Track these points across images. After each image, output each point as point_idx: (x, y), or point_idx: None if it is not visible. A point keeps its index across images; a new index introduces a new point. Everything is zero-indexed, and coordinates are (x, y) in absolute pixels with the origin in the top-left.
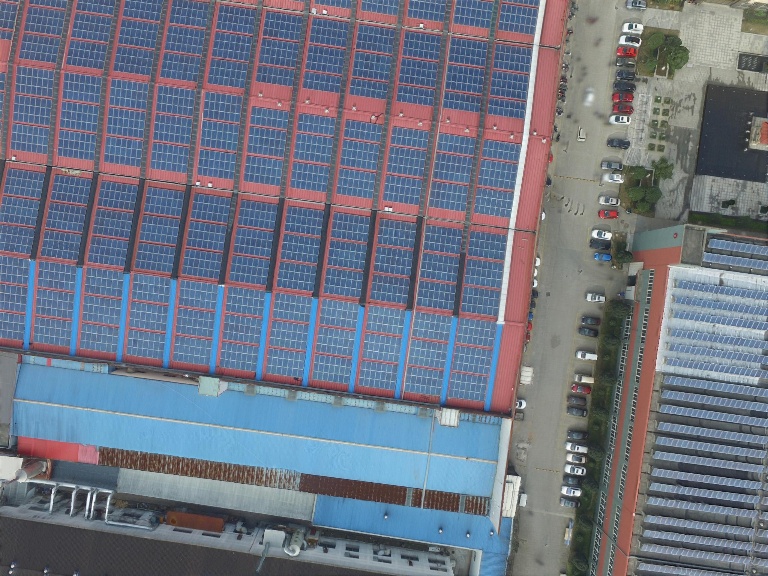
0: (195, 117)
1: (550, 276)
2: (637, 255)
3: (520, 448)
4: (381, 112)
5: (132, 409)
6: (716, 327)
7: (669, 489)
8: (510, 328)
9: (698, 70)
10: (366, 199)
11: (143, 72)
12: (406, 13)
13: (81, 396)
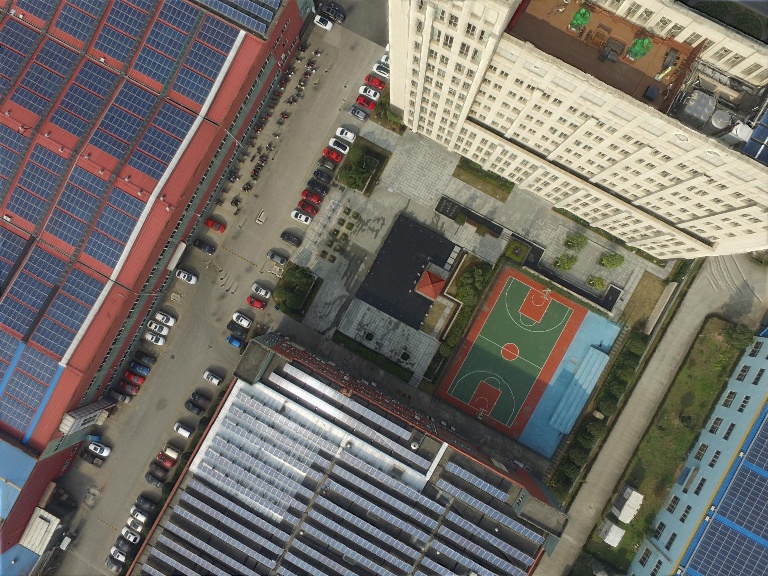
0: None
1: (181, 340)
2: None
3: (91, 493)
4: (31, 126)
5: None
6: (262, 450)
7: None
8: (70, 373)
9: (397, 197)
10: None
11: None
12: (93, 43)
13: None
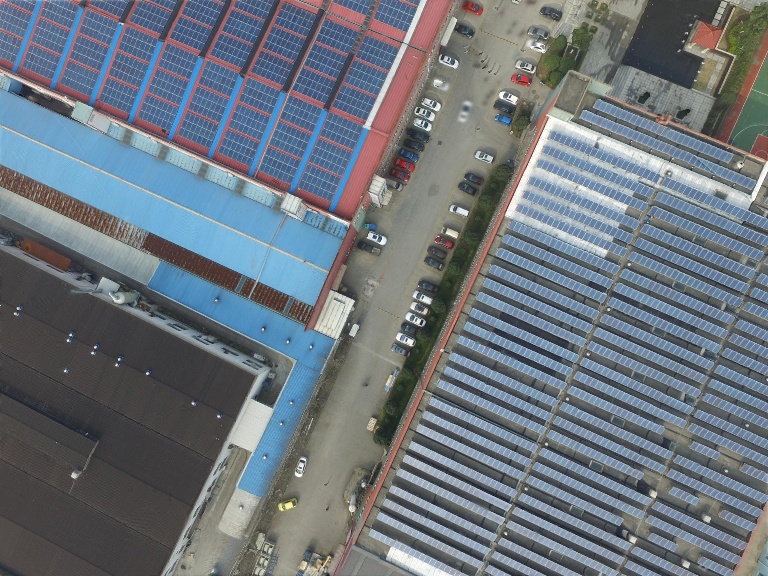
0: None
1: (447, 126)
2: (535, 123)
3: (369, 284)
4: None
5: (18, 127)
6: (578, 189)
7: (483, 334)
8: (375, 136)
9: None
10: None
11: None
12: None
13: None
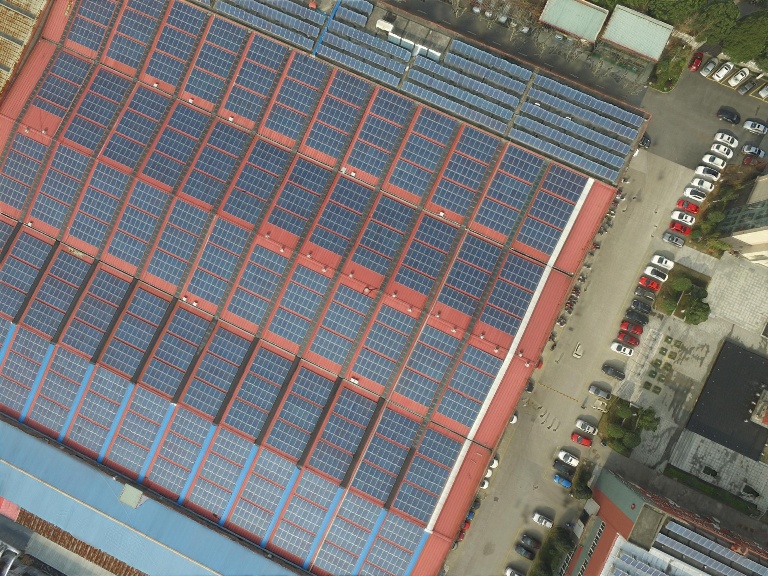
0: (201, 237)
1: (504, 482)
2: (597, 494)
3: None
4: (376, 287)
5: (60, 484)
6: None
7: None
8: (437, 539)
9: (720, 323)
10: (336, 364)
11: (168, 182)
12: (430, 197)
13: (20, 456)
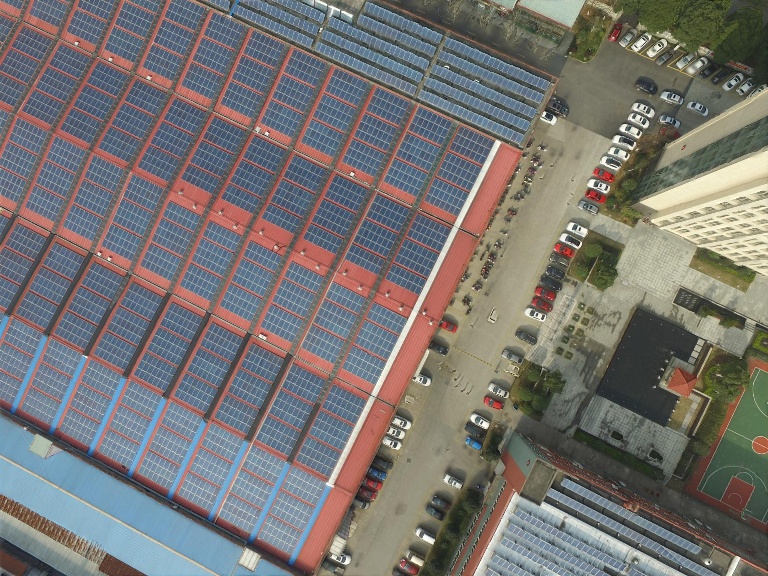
0: (117, 193)
1: (417, 443)
2: (506, 456)
3: None
4: (285, 244)
5: None
6: (543, 568)
7: None
8: (338, 493)
9: (632, 290)
10: (245, 320)
11: (85, 138)
12: (342, 158)
13: None
